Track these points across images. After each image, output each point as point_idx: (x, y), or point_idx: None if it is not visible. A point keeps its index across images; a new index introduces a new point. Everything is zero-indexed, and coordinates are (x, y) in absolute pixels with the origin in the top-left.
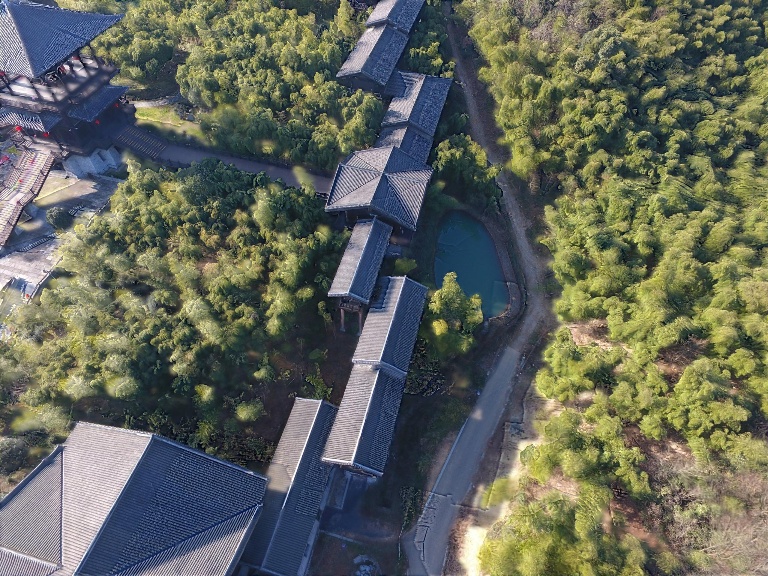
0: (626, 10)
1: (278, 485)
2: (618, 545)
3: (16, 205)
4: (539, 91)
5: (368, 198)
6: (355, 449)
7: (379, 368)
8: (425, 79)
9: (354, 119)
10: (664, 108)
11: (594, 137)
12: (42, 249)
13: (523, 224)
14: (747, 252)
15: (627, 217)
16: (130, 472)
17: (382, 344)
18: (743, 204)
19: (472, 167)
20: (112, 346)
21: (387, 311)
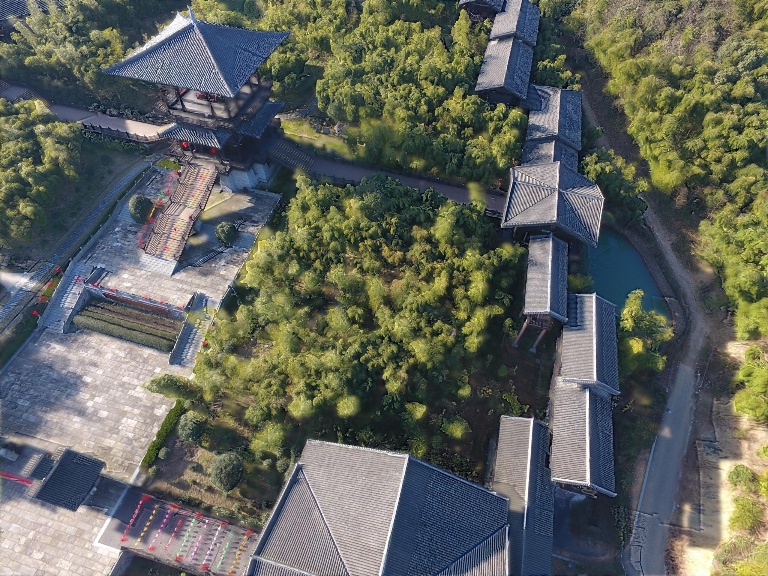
0: (752, 22)
1: (511, 505)
2: None
3: (189, 220)
4: (678, 104)
5: (550, 215)
6: (587, 469)
7: (588, 387)
8: (561, 92)
9: (503, 133)
10: None
11: (744, 151)
12: (214, 264)
13: (667, 238)
14: None
15: None
16: (396, 493)
17: (591, 363)
18: None
19: (619, 181)
20: (324, 363)
21: (585, 329)
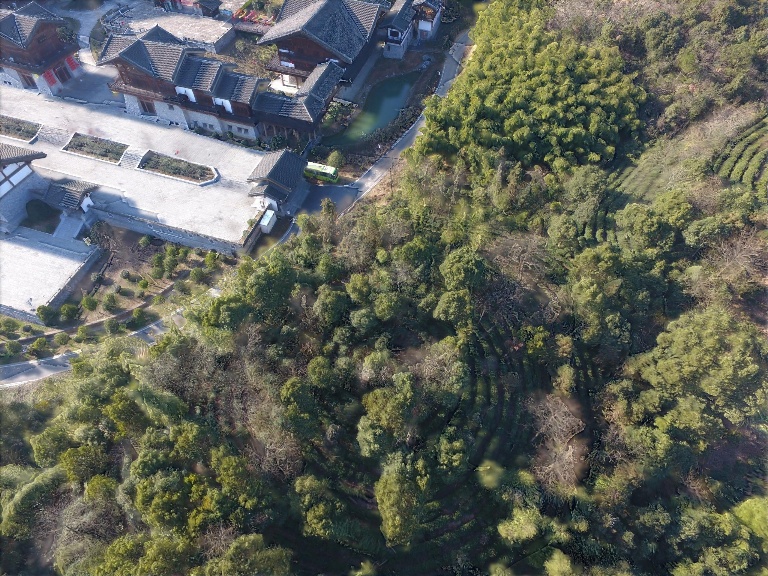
0: None
1: None
2: None
3: None
4: None
5: None
6: None
7: None
8: None
9: None
10: None
11: None
12: None
13: None
14: None
15: None
16: None
17: None
18: None
19: None
20: None
21: None
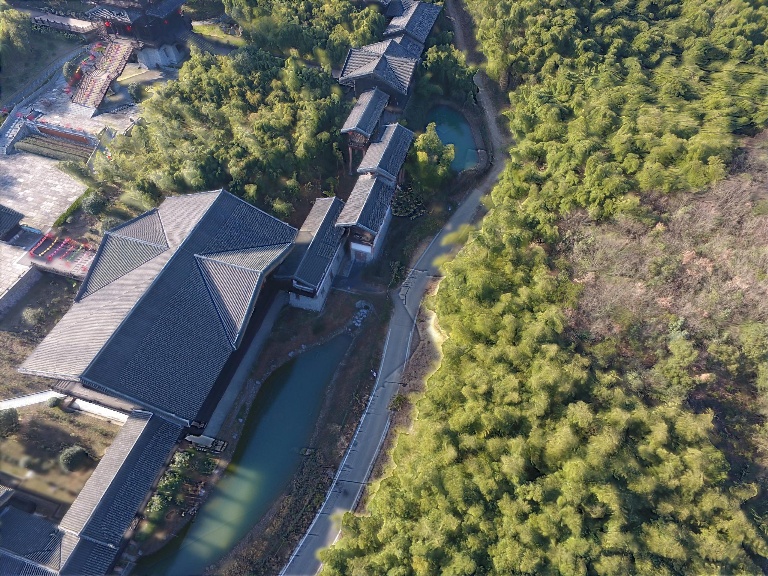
0: None
1: (304, 240)
2: (530, 253)
3: (107, 78)
4: (510, 13)
5: (371, 69)
6: (358, 216)
7: (376, 177)
8: (419, 3)
9: (362, 27)
10: (608, 25)
11: (550, 44)
12: (125, 112)
13: (494, 115)
14: (652, 109)
15: (568, 92)
16: (209, 206)
17: (379, 159)
18: (658, 86)
19: (454, 67)
20: (187, 157)
21: (383, 143)
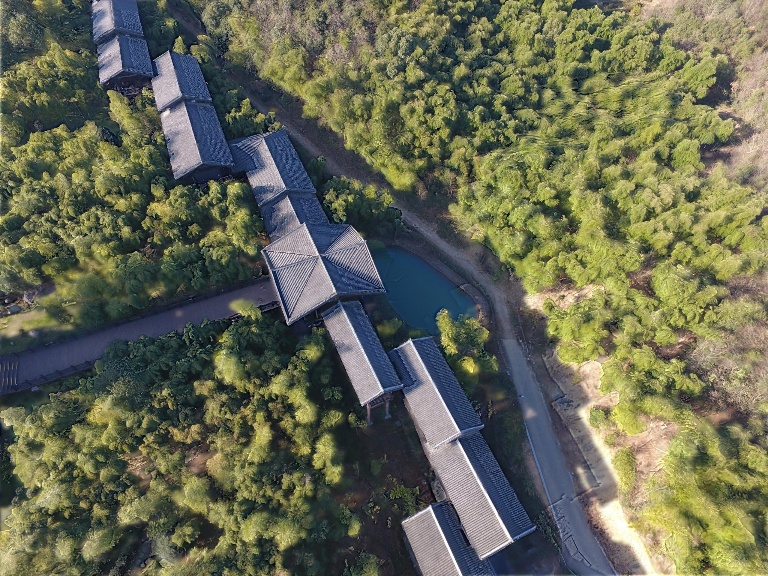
0: (386, 8)
1: None
2: (729, 441)
3: None
4: (372, 107)
5: (328, 288)
6: (503, 526)
7: None
8: (265, 141)
9: (232, 215)
10: (473, 81)
11: (444, 128)
12: None
13: (431, 229)
14: (614, 169)
15: (521, 184)
16: None
17: (446, 415)
18: (579, 133)
19: (365, 203)
20: None
21: (422, 382)
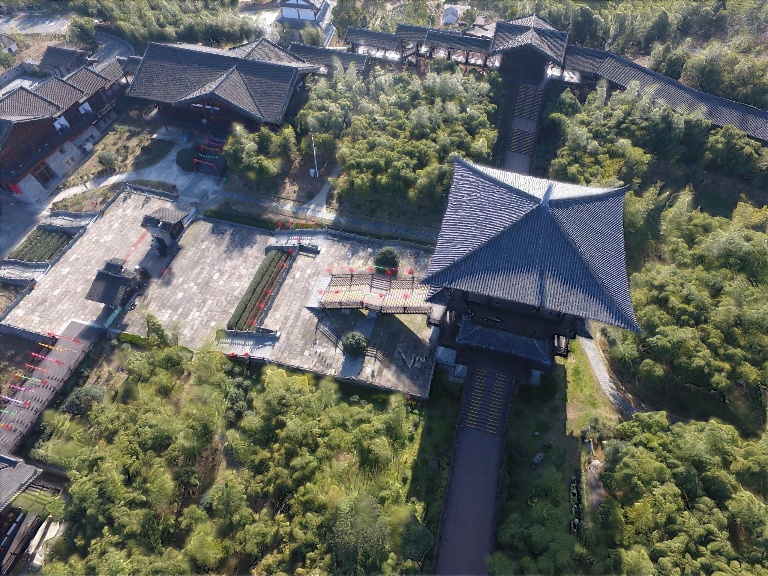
0: None
1: None
2: None
3: (358, 302)
4: None
5: None
6: None
7: None
8: None
9: None
10: None
11: None
12: (320, 341)
13: None
14: None
15: None
16: None
17: None
18: None
19: None
20: None
21: None
